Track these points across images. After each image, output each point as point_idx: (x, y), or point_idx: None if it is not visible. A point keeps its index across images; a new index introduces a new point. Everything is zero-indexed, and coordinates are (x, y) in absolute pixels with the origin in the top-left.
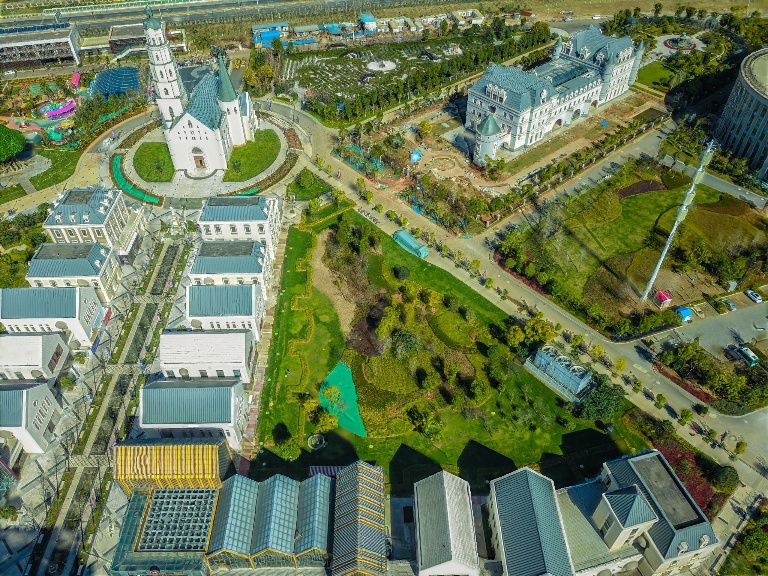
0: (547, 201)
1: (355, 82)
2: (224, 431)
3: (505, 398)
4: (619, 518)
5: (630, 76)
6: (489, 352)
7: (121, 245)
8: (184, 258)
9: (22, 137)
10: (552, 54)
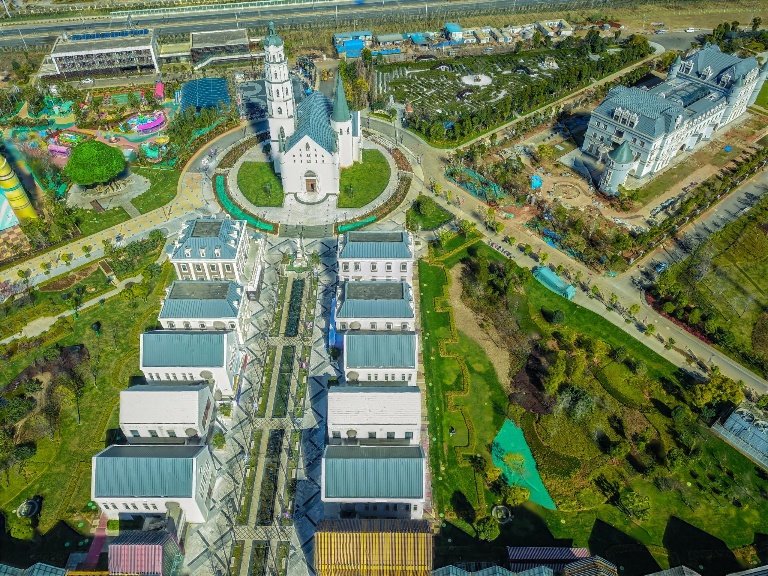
0: (687, 235)
1: (453, 98)
2: (411, 506)
3: (699, 466)
4: None
5: (750, 98)
6: (674, 413)
7: (248, 280)
8: (313, 294)
9: (122, 156)
10: (668, 73)
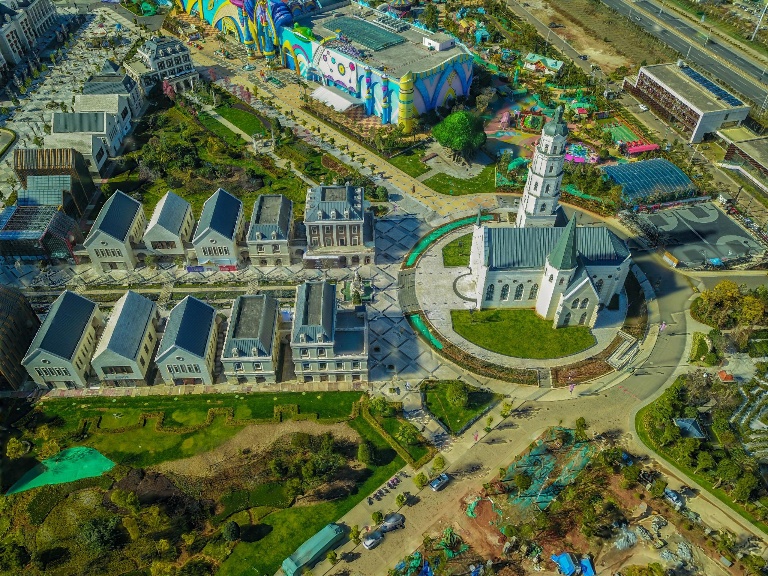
0: None
1: None
2: None
3: None
4: None
5: None
6: None
7: None
8: None
9: (477, 143)
10: None
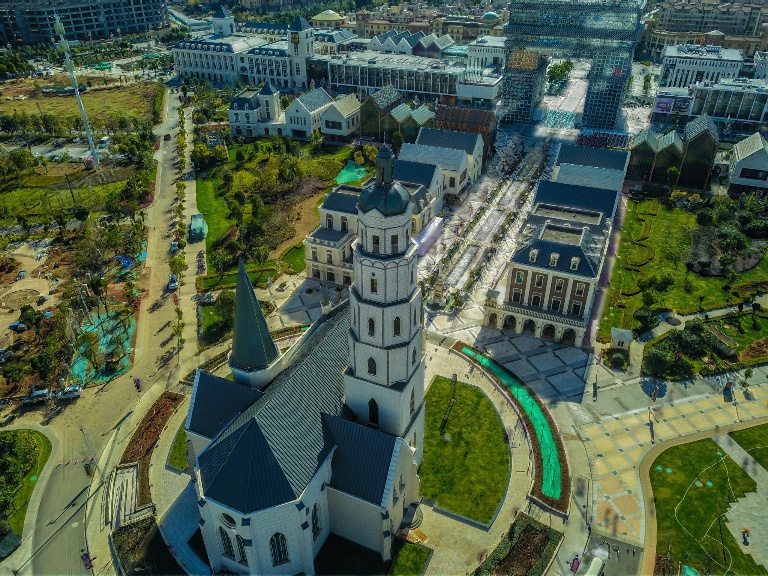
0: None
1: None
2: None
3: None
4: (277, 91)
5: None
6: None
7: None
8: None
9: None
10: None
